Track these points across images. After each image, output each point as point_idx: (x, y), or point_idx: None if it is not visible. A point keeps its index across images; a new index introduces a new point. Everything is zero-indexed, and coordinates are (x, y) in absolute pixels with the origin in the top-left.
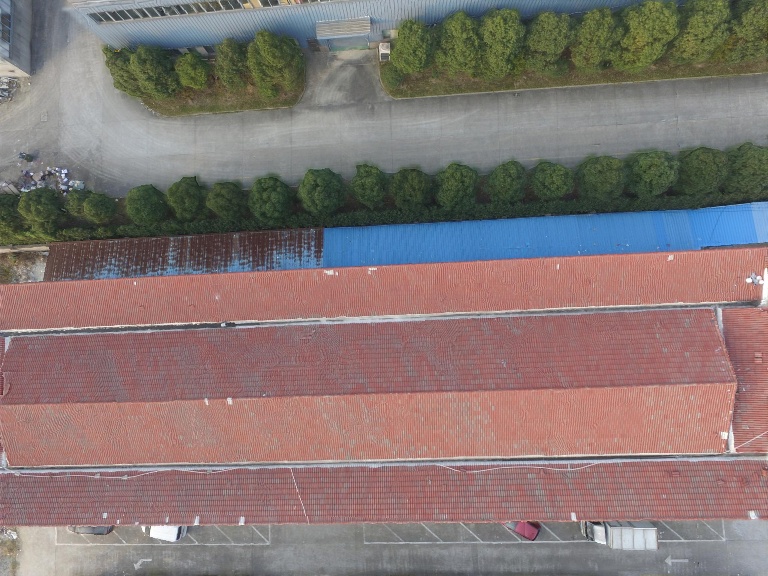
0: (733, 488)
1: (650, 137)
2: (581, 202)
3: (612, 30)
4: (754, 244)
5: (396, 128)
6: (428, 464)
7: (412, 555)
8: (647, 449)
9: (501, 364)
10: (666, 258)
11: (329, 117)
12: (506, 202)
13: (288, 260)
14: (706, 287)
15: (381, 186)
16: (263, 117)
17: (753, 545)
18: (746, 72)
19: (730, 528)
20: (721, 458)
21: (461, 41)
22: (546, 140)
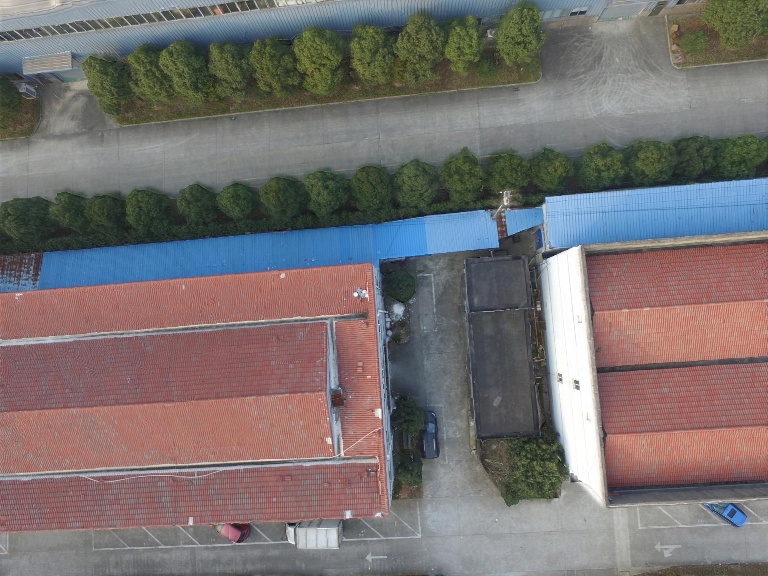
0: (336, 490)
1: (354, 155)
2: (270, 221)
3: (278, 58)
4: (449, 254)
5: (123, 154)
6: (73, 475)
7: (136, 560)
8: (264, 455)
9: (125, 380)
10: (279, 276)
11: (62, 145)
12: (199, 223)
13: (7, 284)
14: (311, 302)
15: (79, 212)
16: (3, 147)
17: (446, 540)
18: (442, 90)
19: (425, 525)
20: (333, 462)
21: (141, 73)
22: (259, 161)
